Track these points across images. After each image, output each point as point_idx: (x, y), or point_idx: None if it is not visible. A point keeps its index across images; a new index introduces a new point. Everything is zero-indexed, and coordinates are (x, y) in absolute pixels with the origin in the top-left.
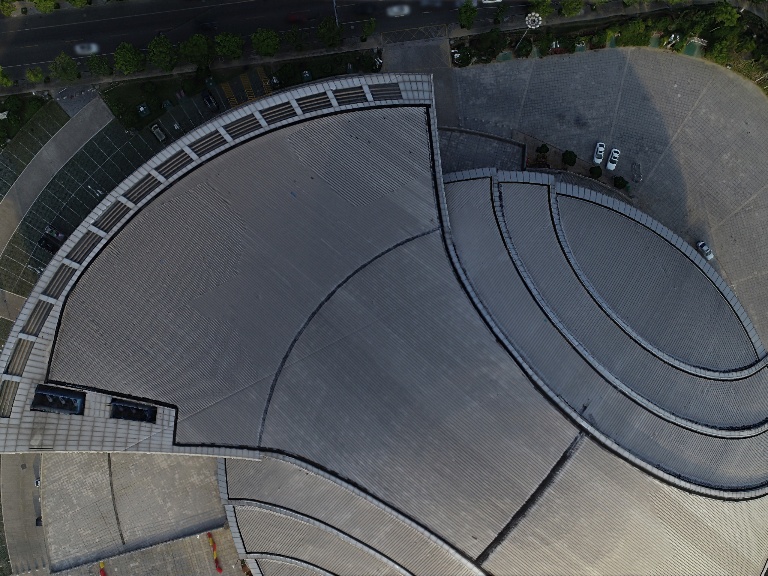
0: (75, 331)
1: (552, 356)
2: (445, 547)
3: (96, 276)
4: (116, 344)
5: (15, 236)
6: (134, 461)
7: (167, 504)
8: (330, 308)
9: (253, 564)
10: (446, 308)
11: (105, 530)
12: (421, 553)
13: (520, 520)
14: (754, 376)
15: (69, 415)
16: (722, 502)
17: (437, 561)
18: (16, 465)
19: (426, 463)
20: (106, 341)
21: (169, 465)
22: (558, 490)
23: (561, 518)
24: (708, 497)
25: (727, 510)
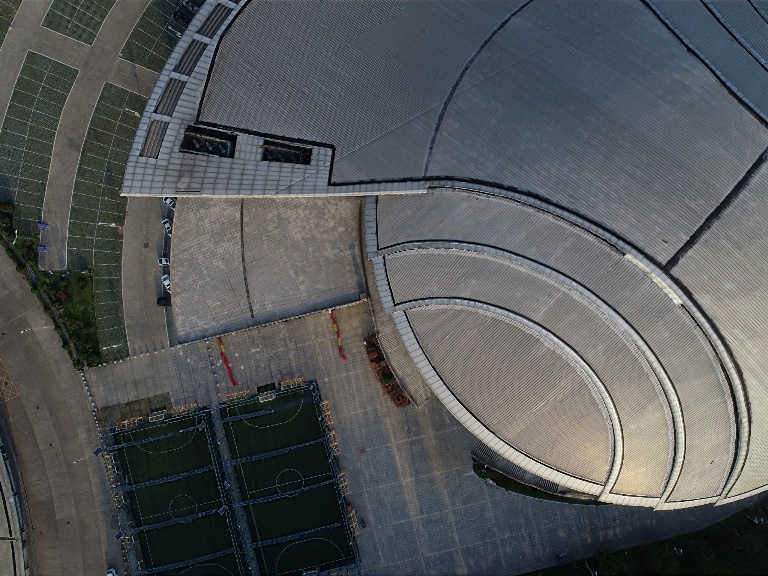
0: (229, 72)
1: (741, 71)
2: (633, 252)
3: (253, 16)
4: (271, 85)
5: (149, 9)
6: (267, 232)
7: (299, 277)
8: (504, 35)
9: (401, 318)
10: (631, 24)
11: (234, 302)
12: (602, 267)
13: (714, 222)
14: None
15: (219, 158)
16: None
17: (619, 275)
18: (139, 244)
19: (616, 166)
20: (261, 82)
21: (303, 237)
22: (753, 193)
23: (755, 222)
24: None
25: None
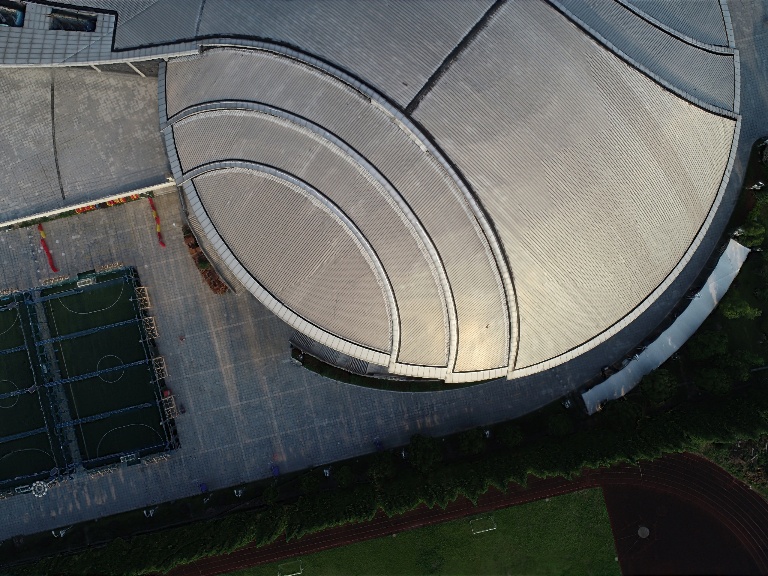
0: None
1: None
2: (375, 96)
3: None
4: None
5: None
6: (78, 114)
7: (109, 159)
8: None
9: (189, 187)
10: None
11: (45, 184)
12: (352, 115)
13: (451, 64)
14: (703, 0)
15: (8, 27)
16: (662, 90)
17: (368, 122)
18: None
19: (359, 10)
20: None
21: (113, 119)
22: (491, 34)
23: (493, 64)
24: (647, 77)
25: (667, 102)
